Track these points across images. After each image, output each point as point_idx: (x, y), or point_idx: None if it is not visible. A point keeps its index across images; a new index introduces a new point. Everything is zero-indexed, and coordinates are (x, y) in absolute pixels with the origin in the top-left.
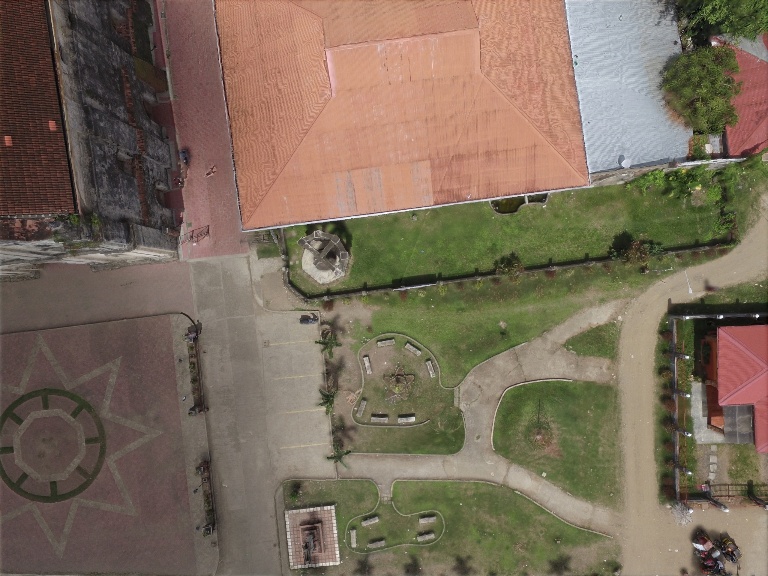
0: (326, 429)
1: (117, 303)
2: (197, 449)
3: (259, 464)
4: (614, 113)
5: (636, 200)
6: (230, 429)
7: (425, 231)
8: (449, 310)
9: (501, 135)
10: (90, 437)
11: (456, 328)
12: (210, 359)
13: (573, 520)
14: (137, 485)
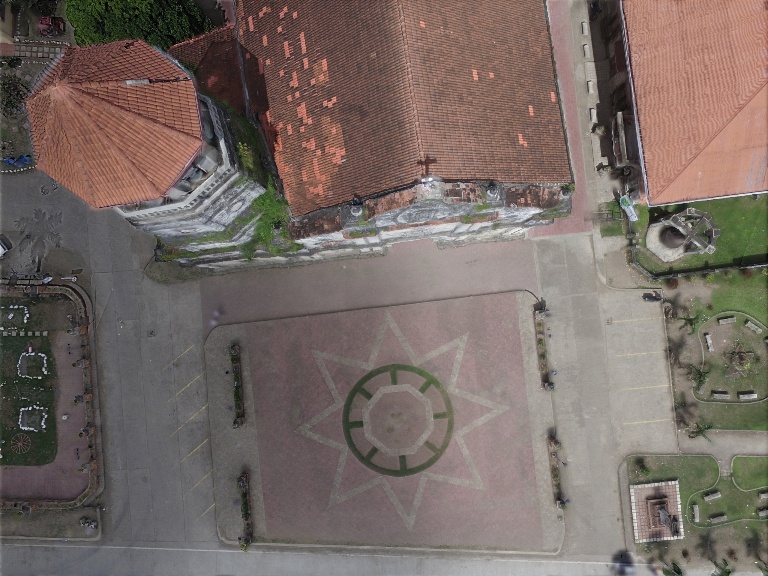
0: (668, 405)
1: (462, 280)
2: (543, 424)
3: (602, 439)
4: None
5: None
6: (574, 405)
7: (765, 210)
8: None
9: None
10: (438, 412)
11: None
12: (554, 336)
13: None
14: (485, 459)
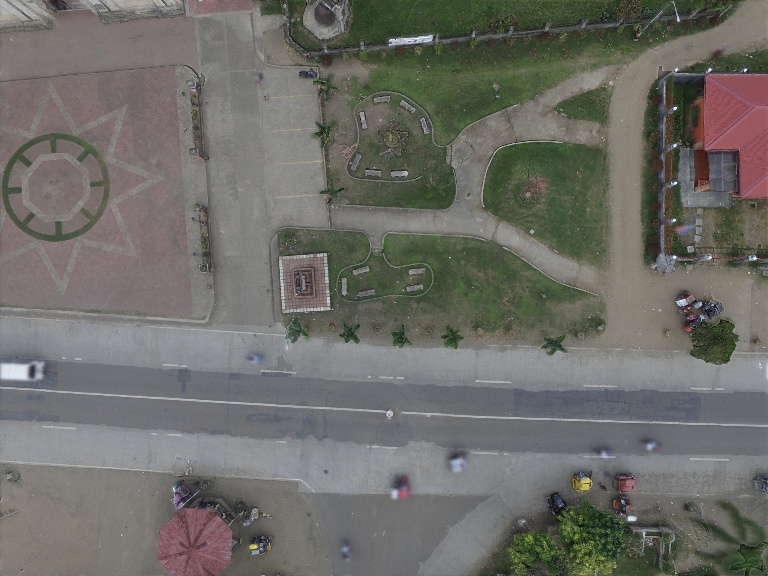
0: (321, 181)
1: (125, 55)
2: (196, 195)
3: (256, 212)
4: None
5: None
6: (229, 178)
7: None
8: (444, 71)
9: None
10: (95, 180)
11: (450, 89)
12: (212, 110)
13: (559, 277)
14: (138, 227)
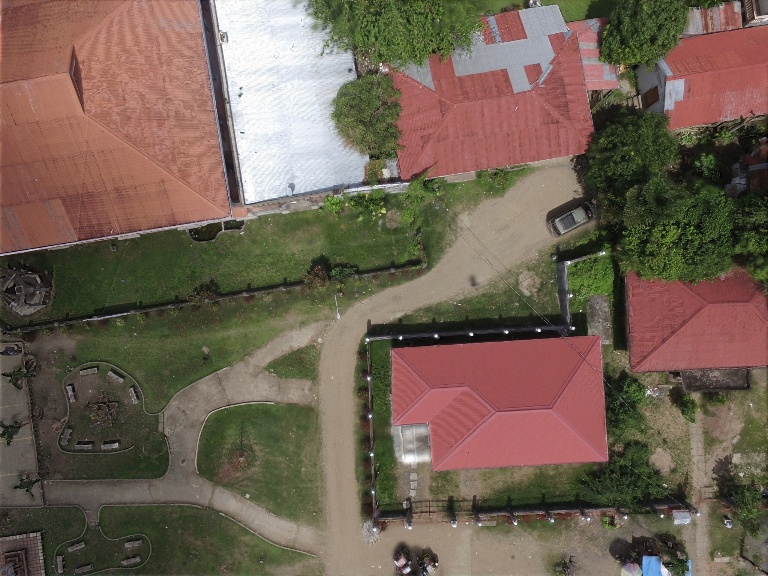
0: (32, 457)
1: None
2: None
3: None
4: (284, 142)
5: (332, 224)
6: None
7: (125, 261)
8: (152, 337)
9: (125, 172)
10: None
11: (159, 355)
12: None
13: (278, 540)
14: None
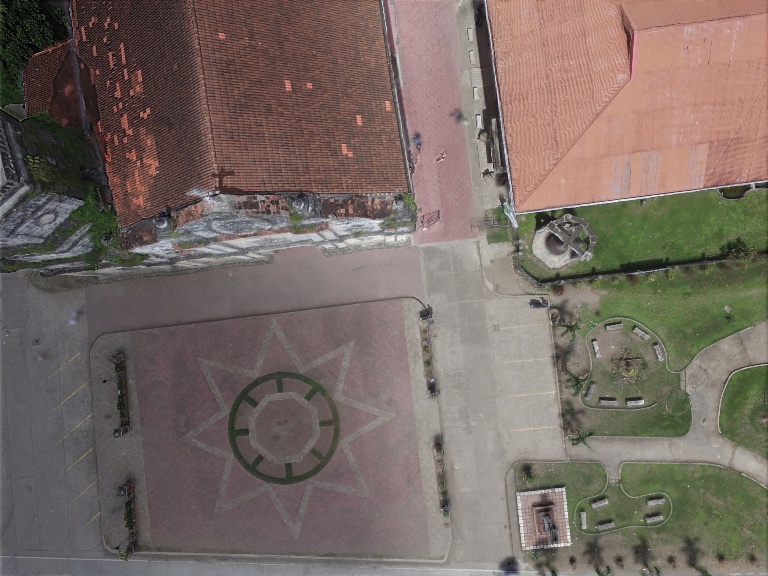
0: (556, 412)
1: (348, 287)
2: (429, 432)
3: (490, 446)
4: None
5: None
6: (461, 412)
7: (652, 216)
8: (675, 294)
9: None
10: (324, 420)
11: (682, 312)
12: (441, 343)
13: None
14: (371, 467)
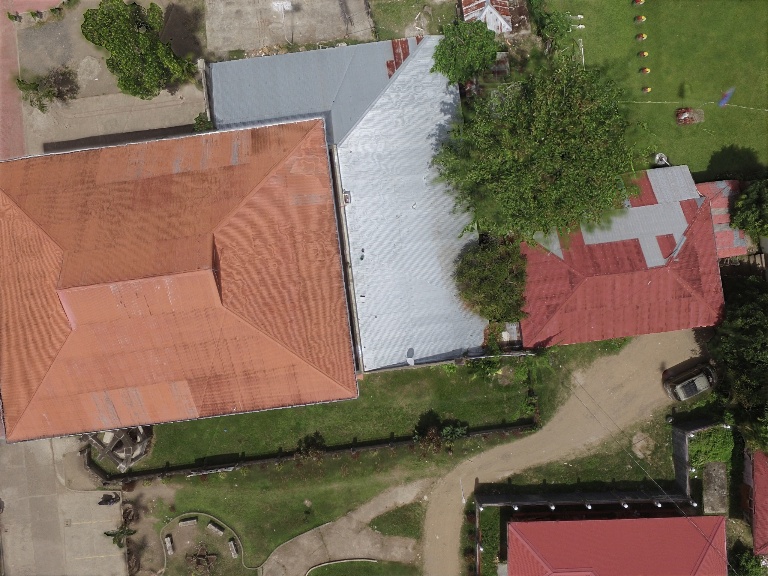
0: None
1: None
2: None
3: None
4: (404, 305)
5: (442, 379)
6: None
7: None
8: (253, 489)
9: (256, 357)
10: None
11: (260, 507)
12: (12, 538)
13: None
14: None
